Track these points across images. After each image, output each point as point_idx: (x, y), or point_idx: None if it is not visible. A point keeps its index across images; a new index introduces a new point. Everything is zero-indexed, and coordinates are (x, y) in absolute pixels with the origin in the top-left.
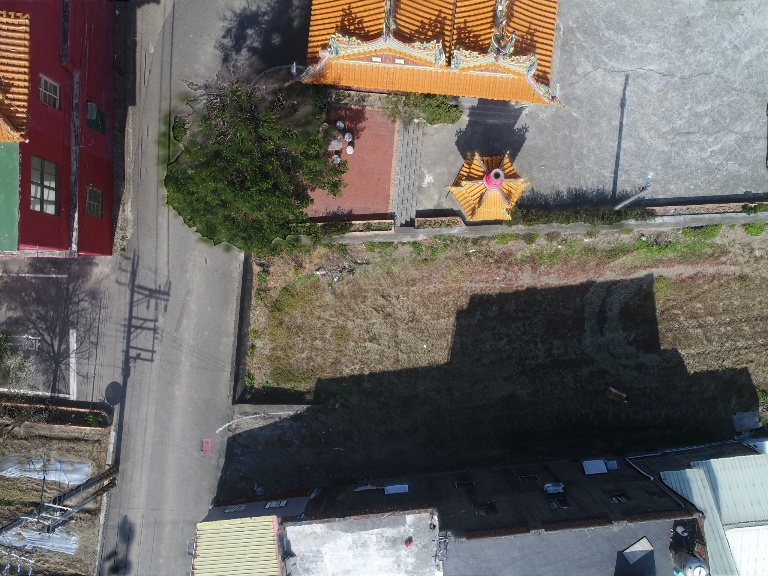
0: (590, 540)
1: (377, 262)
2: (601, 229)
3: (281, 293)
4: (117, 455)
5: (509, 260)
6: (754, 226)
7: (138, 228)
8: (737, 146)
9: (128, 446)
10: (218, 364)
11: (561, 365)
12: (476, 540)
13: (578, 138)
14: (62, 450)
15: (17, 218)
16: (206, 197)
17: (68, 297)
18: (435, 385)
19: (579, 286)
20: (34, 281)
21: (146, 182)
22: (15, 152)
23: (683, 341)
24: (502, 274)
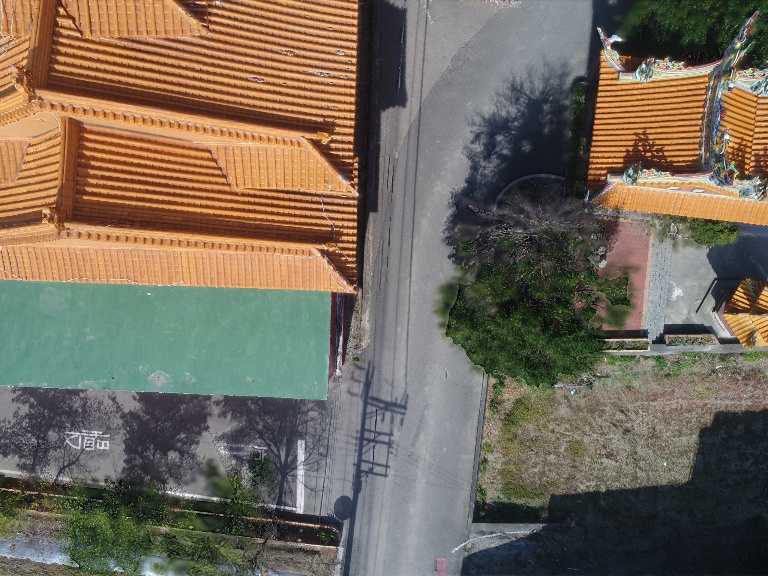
0: None
1: (617, 375)
2: None
3: (516, 405)
4: (346, 572)
5: (757, 377)
6: None
7: (375, 338)
8: None
9: (358, 563)
10: (456, 482)
11: None
12: None
13: None
14: (280, 561)
15: (328, 365)
16: (501, 334)
17: (297, 406)
18: (675, 505)
19: None
20: None
21: (386, 291)
22: (327, 295)
23: None
24: (750, 392)
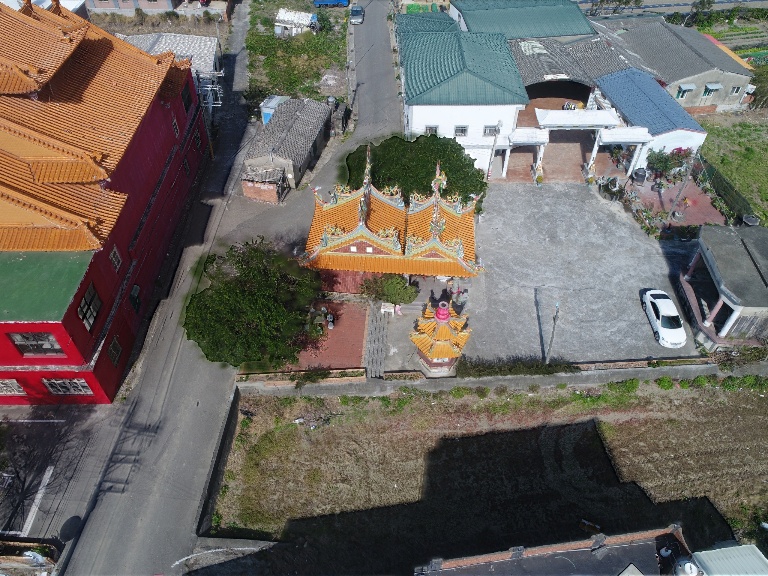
0: (576, 570)
1: (350, 414)
2: (540, 384)
3: (260, 439)
4: None
5: (467, 411)
6: (664, 380)
7: (143, 380)
8: (629, 329)
9: None
10: (189, 493)
11: (530, 500)
12: (454, 573)
13: (508, 324)
14: None
15: (70, 301)
16: (218, 312)
17: (58, 438)
18: (407, 523)
19: (532, 430)
20: (30, 426)
21: (161, 347)
22: (86, 265)
23: (638, 475)
24: (462, 422)
